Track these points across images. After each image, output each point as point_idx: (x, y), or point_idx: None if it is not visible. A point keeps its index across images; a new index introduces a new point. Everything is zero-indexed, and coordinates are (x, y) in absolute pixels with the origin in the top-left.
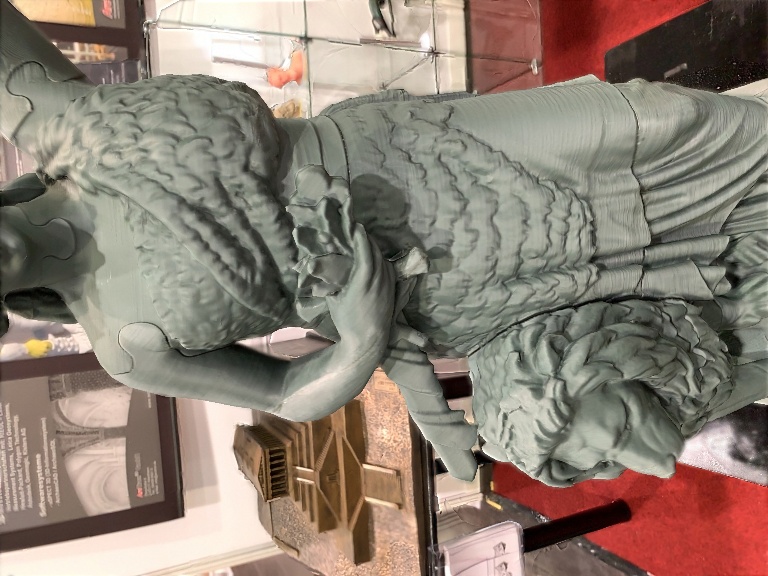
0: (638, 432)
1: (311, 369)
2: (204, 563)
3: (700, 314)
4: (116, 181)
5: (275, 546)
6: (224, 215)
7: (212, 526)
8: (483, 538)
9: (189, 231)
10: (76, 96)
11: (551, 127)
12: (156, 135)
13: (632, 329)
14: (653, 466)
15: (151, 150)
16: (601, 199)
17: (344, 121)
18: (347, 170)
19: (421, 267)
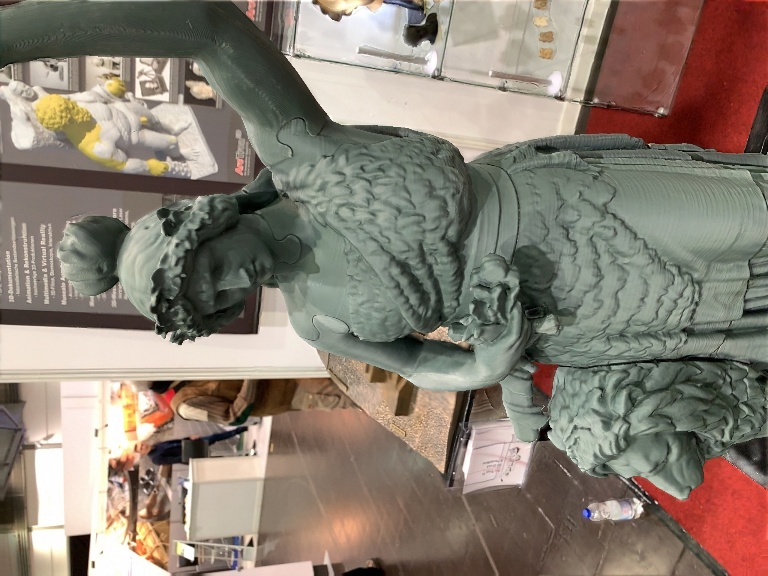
0: (671, 465)
1: (443, 364)
2: (265, 371)
3: (757, 377)
4: (347, 231)
5: (325, 371)
6: (419, 269)
7: (277, 344)
8: (506, 427)
9: (393, 281)
10: (326, 152)
11: (693, 228)
12: (385, 206)
13: (696, 393)
14: (673, 491)
15: (379, 216)
16: (712, 283)
17: (523, 189)
18: (516, 239)
19: (552, 331)
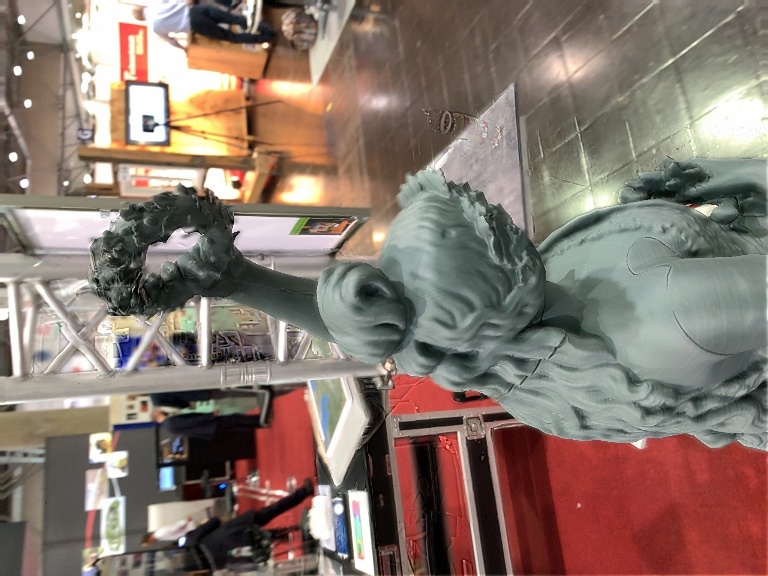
0: None
1: None
2: None
3: None
4: None
5: None
6: None
7: None
8: None
9: None
10: None
11: None
12: None
13: None
14: None
15: None
16: None
17: None
18: None
19: None
